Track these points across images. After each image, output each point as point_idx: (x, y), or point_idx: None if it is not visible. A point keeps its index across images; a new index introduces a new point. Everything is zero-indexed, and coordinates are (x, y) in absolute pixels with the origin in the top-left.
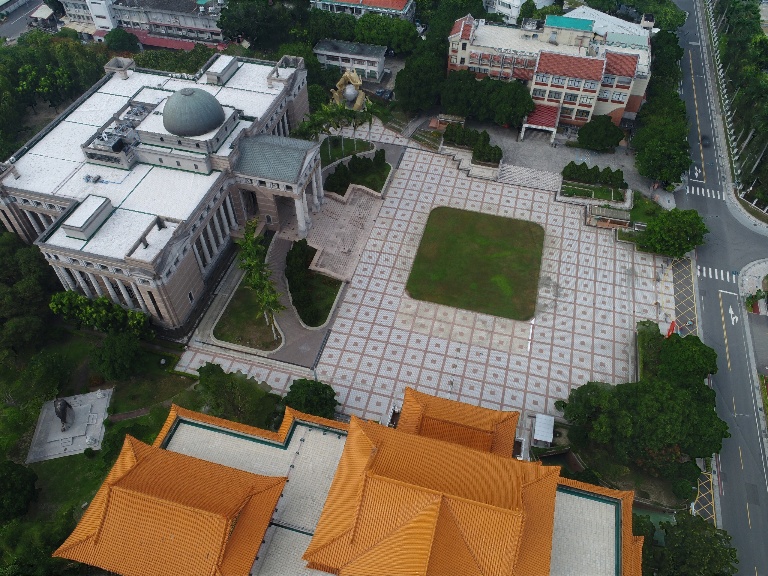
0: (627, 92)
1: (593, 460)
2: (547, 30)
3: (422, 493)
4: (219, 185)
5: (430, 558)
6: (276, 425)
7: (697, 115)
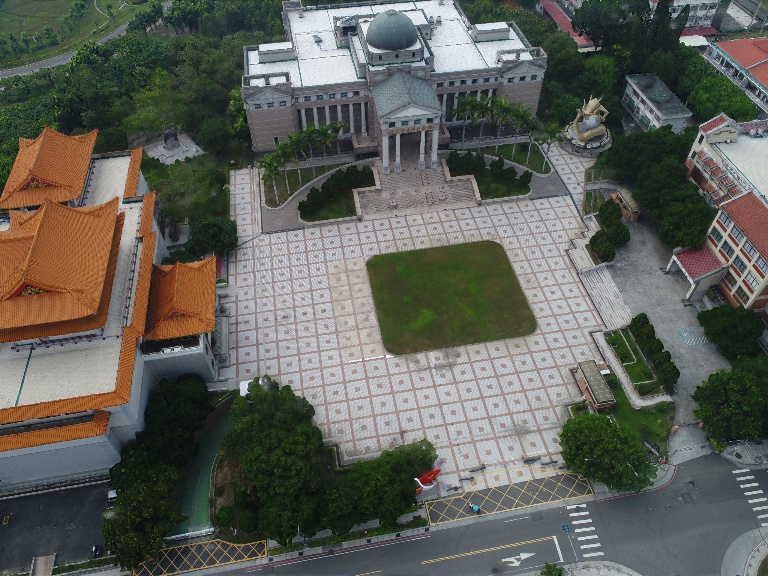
0: None
1: None
2: None
3: None
4: (354, 88)
5: None
6: None
7: None
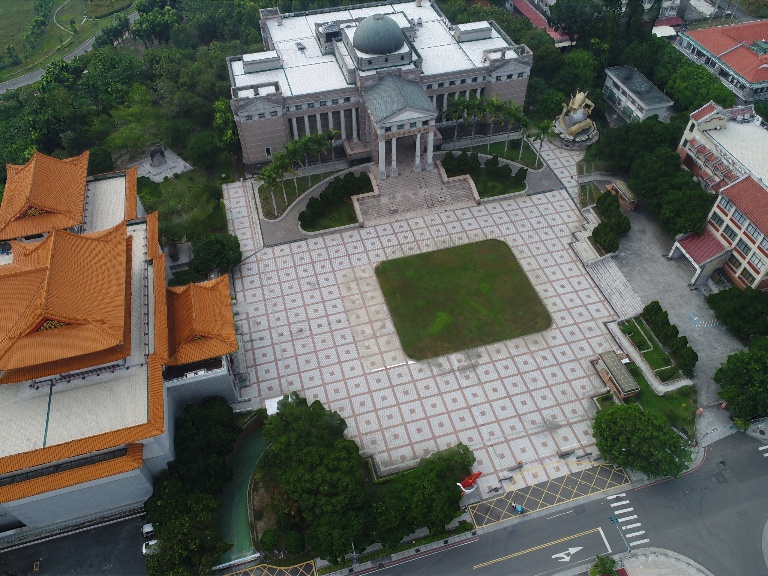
0: None
1: None
2: None
3: None
4: (345, 94)
5: (1, 279)
6: None
7: None
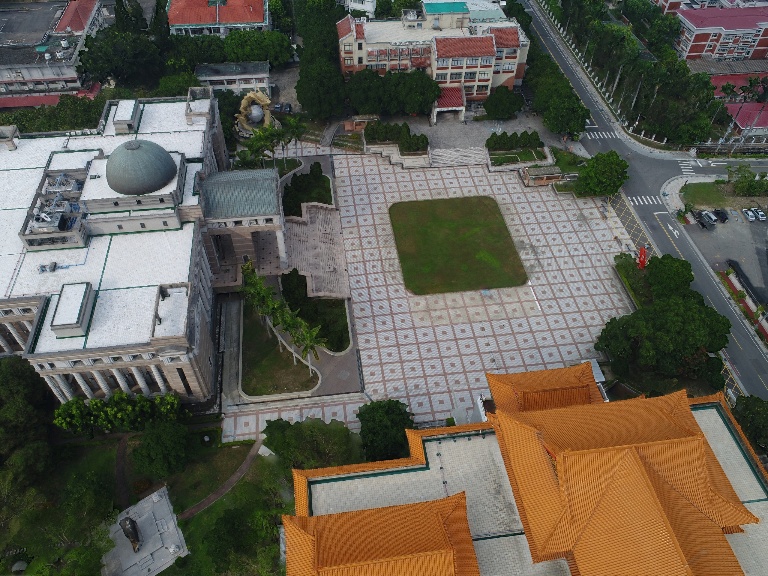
0: (515, 61)
1: (639, 384)
2: (429, 18)
3: (615, 452)
4: (197, 237)
5: None
6: (368, 456)
7: (562, 71)
